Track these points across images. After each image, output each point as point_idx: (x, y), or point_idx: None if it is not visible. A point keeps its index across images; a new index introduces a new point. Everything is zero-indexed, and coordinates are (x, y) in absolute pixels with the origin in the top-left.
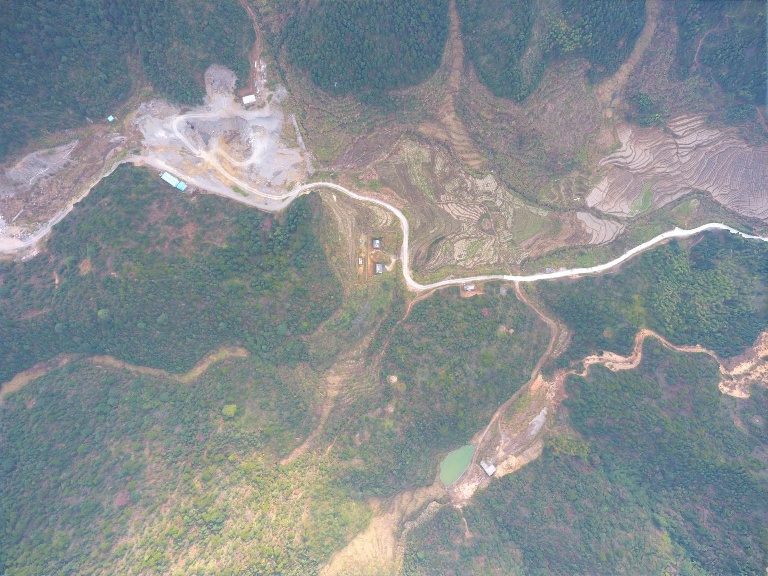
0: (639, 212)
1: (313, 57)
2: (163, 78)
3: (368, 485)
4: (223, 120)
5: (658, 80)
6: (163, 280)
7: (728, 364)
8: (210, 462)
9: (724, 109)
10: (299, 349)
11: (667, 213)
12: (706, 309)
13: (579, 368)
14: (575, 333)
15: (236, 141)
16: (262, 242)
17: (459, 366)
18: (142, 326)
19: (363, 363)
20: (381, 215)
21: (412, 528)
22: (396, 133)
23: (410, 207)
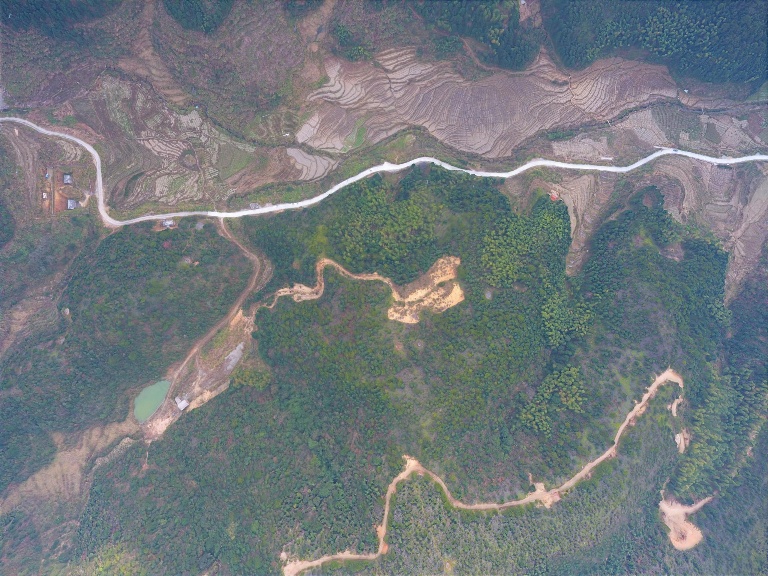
0: (352, 148)
1: None
2: None
3: (41, 418)
4: None
5: (354, 11)
6: None
7: (403, 291)
8: None
9: (431, 42)
10: None
11: (381, 149)
12: (391, 238)
13: (268, 300)
14: (275, 267)
15: None
16: None
17: (121, 295)
18: None
19: None
20: (69, 149)
21: (102, 464)
22: (96, 69)
23: (104, 142)
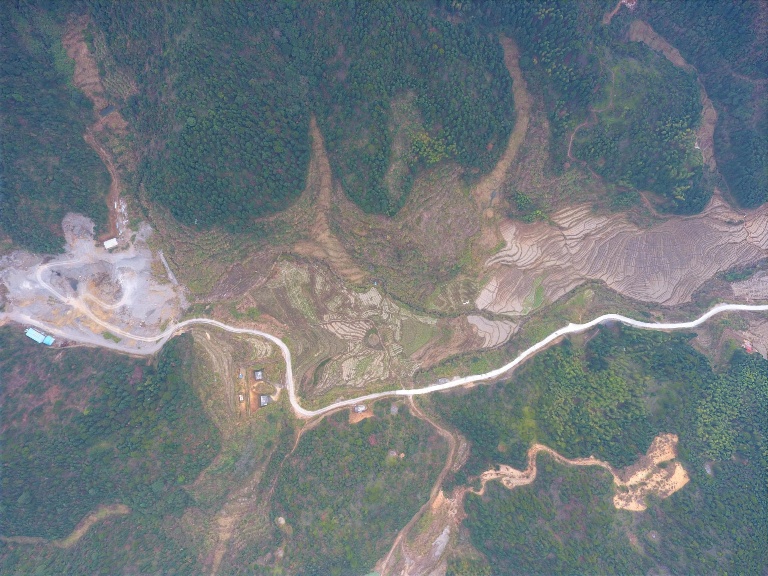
0: (532, 309)
1: (169, 197)
2: (18, 232)
3: None
4: (88, 265)
5: (534, 178)
6: (18, 461)
7: (623, 475)
8: None
9: (608, 198)
10: (182, 498)
11: (561, 307)
12: (599, 415)
13: (476, 486)
14: (473, 445)
15: (106, 283)
16: (131, 396)
17: (343, 507)
18: (1, 510)
19: (255, 500)
20: (259, 347)
21: None
22: (272, 256)
23: (291, 333)
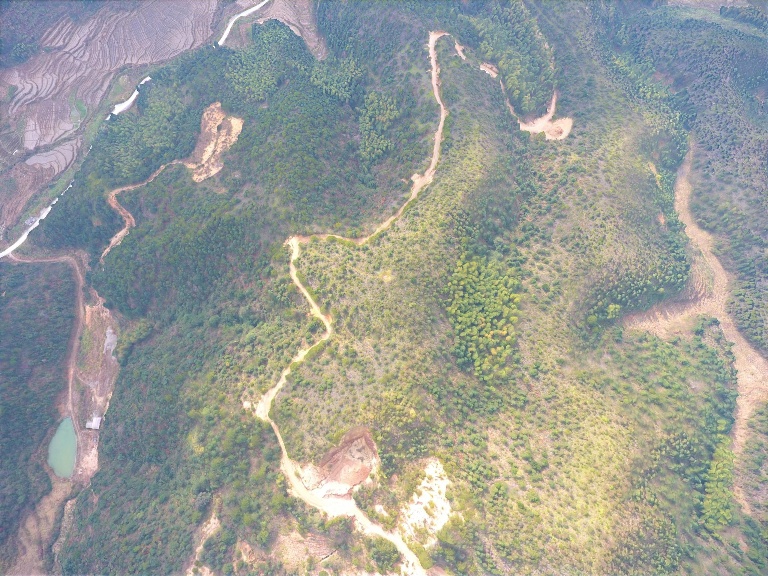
0: (82, 120)
1: None
2: None
3: None
4: None
5: None
6: None
7: (194, 158)
8: None
9: (75, 2)
10: None
11: (106, 103)
12: (155, 137)
13: (97, 270)
14: None
15: None
16: None
17: None
18: None
19: None
20: None
21: (61, 547)
22: None
23: None
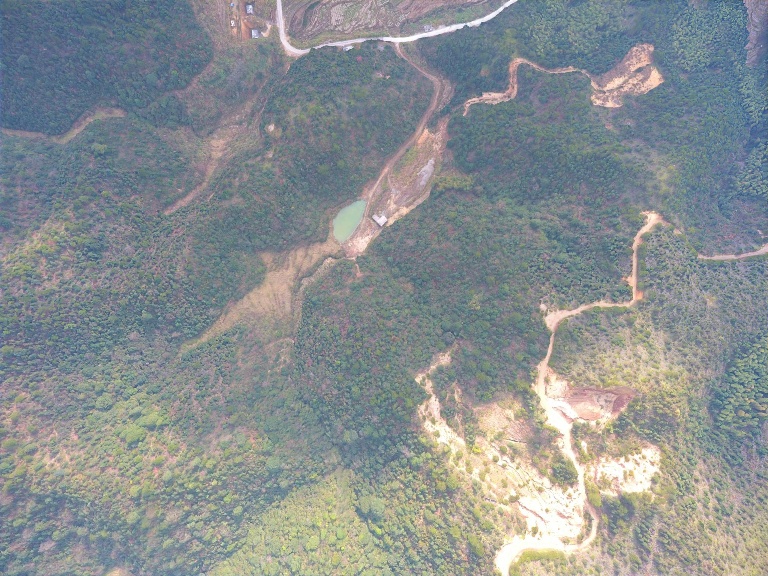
0: None
1: None
2: None
3: (255, 233)
4: None
5: None
6: (18, 18)
7: (601, 80)
8: (81, 193)
9: None
10: (176, 108)
11: None
12: (578, 36)
13: (459, 110)
14: (457, 84)
15: None
16: None
17: (330, 99)
18: (2, 66)
19: (246, 126)
20: None
21: (309, 283)
22: None
23: None
